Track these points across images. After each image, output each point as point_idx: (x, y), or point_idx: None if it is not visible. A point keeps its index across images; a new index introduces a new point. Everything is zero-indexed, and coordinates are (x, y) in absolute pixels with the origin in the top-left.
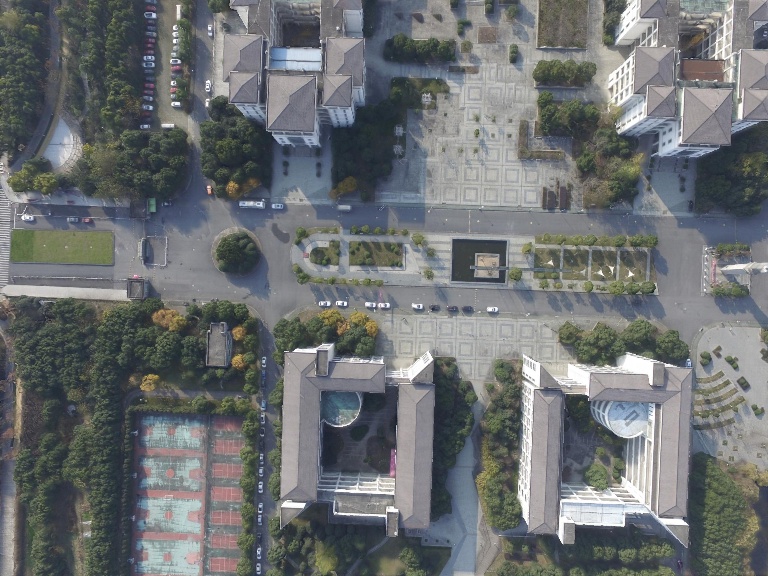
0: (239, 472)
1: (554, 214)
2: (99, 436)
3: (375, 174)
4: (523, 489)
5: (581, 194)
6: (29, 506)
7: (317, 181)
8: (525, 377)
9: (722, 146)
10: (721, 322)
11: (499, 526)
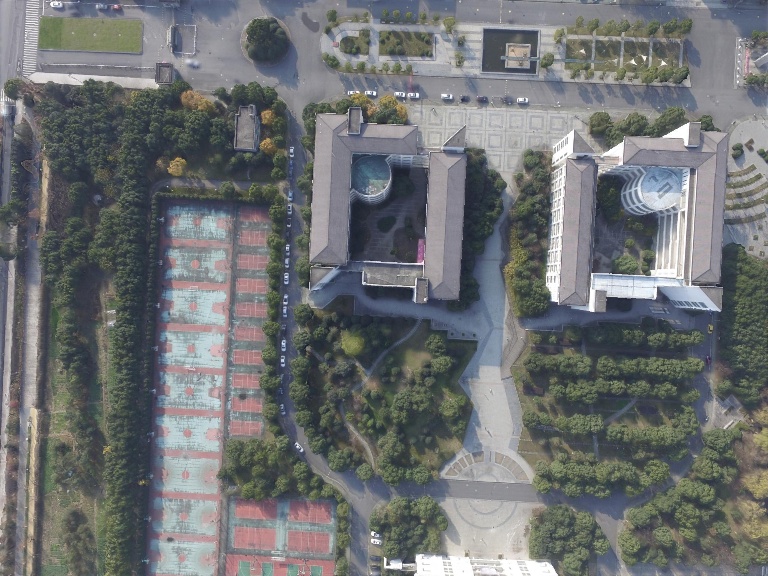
0: (265, 263)
1: (586, 5)
2: (126, 215)
3: None
4: (552, 274)
5: None
6: (53, 296)
7: None
8: (555, 164)
9: None
10: (754, 115)
11: (528, 308)
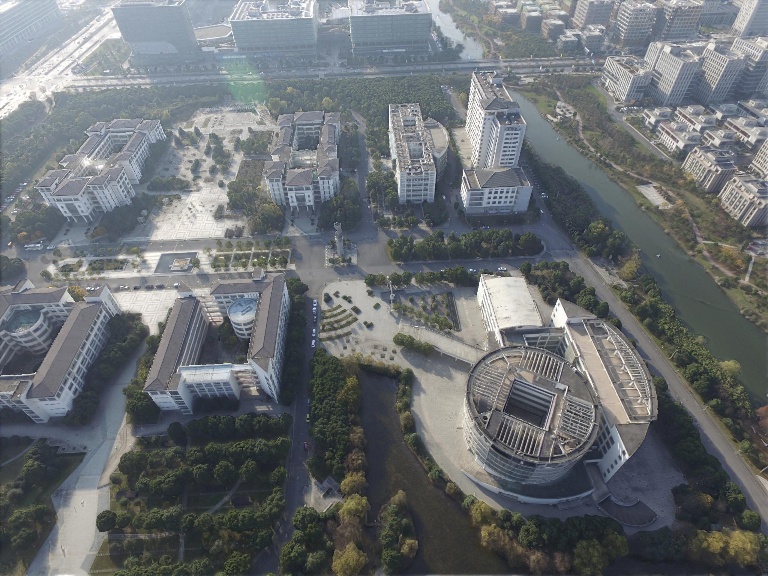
0: None
1: (232, 239)
2: None
3: (121, 228)
4: None
5: (250, 230)
6: None
7: (84, 236)
8: None
9: (327, 200)
10: (338, 279)
11: (128, 407)
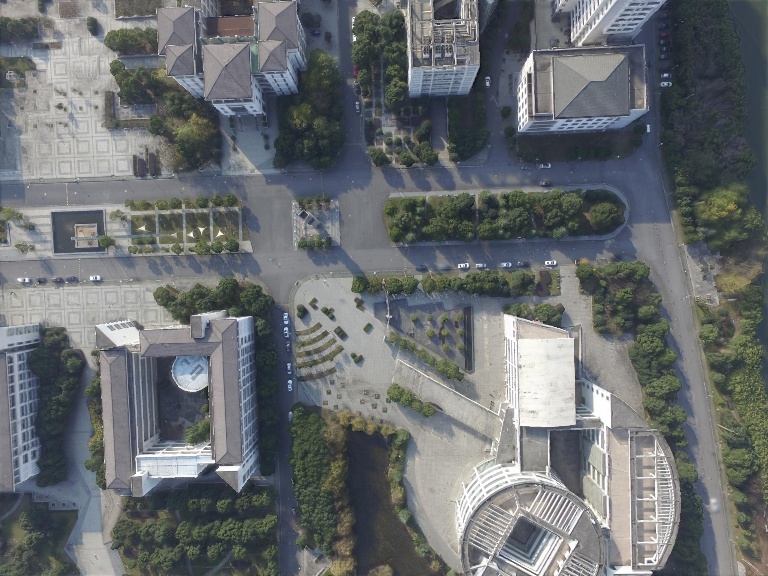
0: None
1: (147, 181)
2: None
3: None
4: None
5: None
6: None
7: None
8: None
9: (284, 101)
10: (314, 274)
11: (99, 485)
